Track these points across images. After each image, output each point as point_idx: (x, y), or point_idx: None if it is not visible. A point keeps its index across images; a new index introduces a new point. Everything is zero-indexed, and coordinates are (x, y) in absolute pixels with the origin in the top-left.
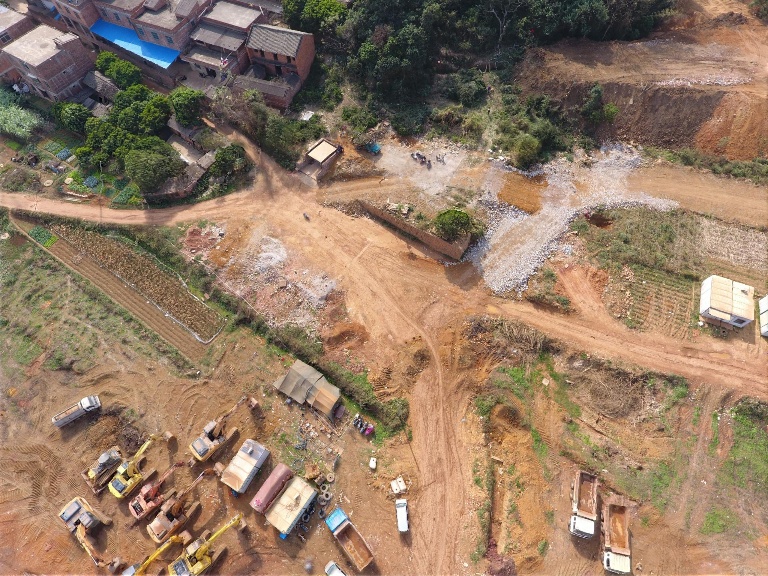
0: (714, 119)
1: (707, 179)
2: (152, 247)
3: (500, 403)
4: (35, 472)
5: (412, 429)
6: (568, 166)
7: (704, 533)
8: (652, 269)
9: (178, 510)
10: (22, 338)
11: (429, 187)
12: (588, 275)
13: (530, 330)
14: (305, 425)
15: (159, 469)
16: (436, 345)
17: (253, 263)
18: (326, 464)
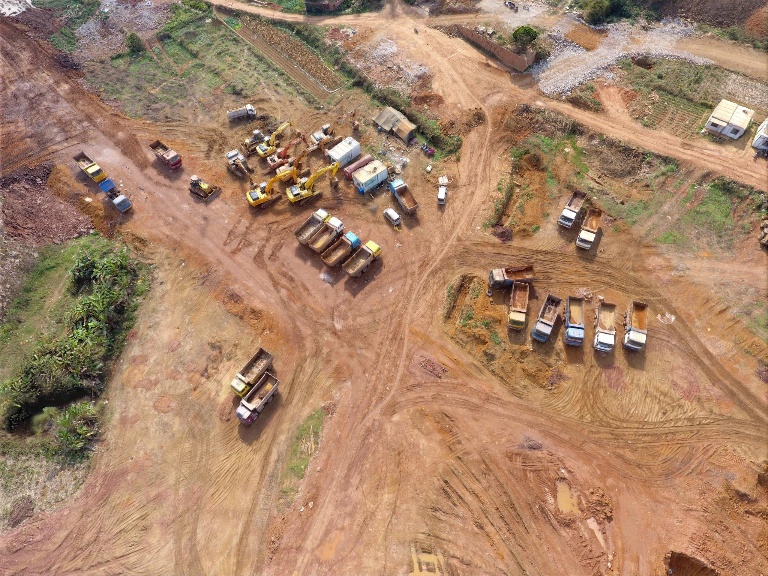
0: (766, 7)
1: (746, 51)
2: (305, 34)
3: (529, 153)
4: (211, 140)
5: (461, 156)
6: (629, 27)
7: (658, 241)
8: (675, 97)
9: (298, 164)
10: (212, 74)
11: (512, 22)
12: (621, 92)
13: (564, 116)
14: (387, 143)
15: (287, 151)
16: (491, 114)
17: (372, 51)
18: (397, 165)
